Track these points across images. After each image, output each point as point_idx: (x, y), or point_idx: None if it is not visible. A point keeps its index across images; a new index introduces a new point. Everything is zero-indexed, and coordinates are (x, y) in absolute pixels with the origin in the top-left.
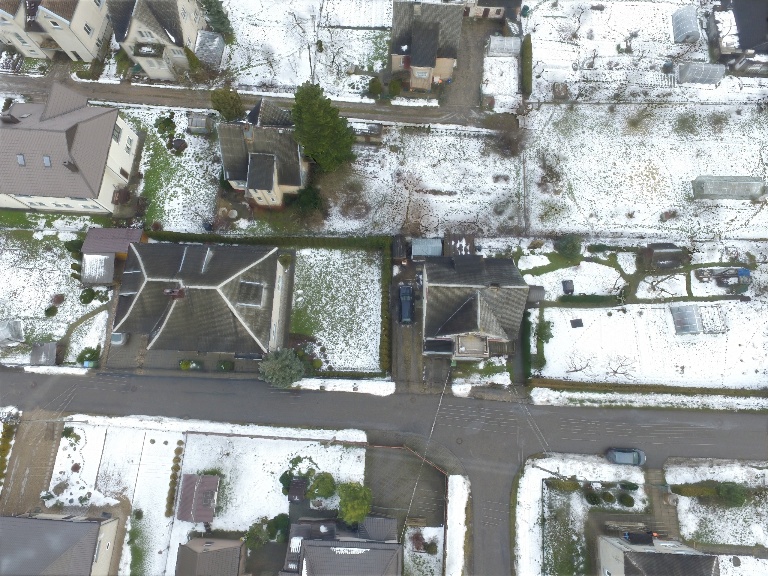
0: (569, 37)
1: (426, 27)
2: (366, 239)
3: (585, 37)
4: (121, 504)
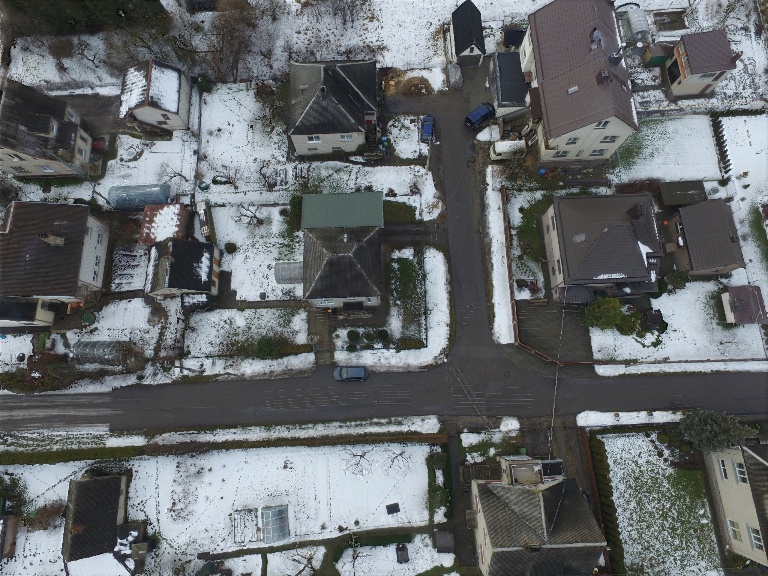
0: None
1: None
2: None
3: None
4: None
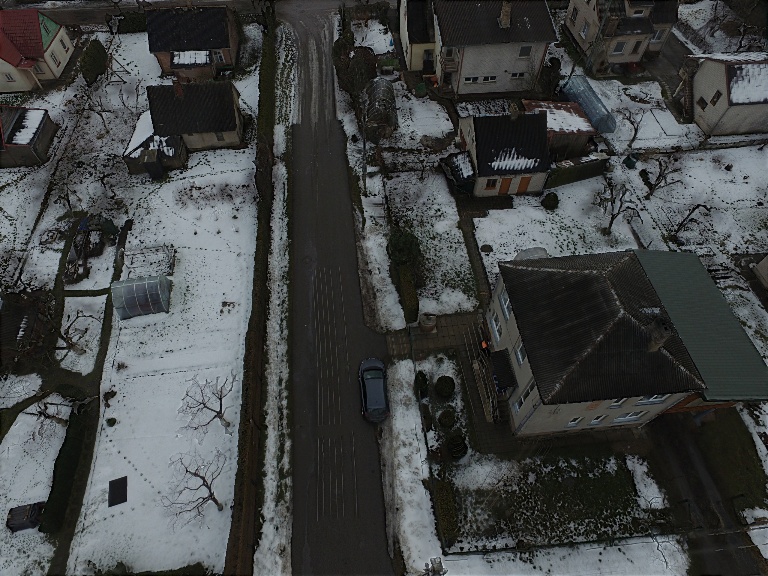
0: None
1: None
2: None
3: None
4: None
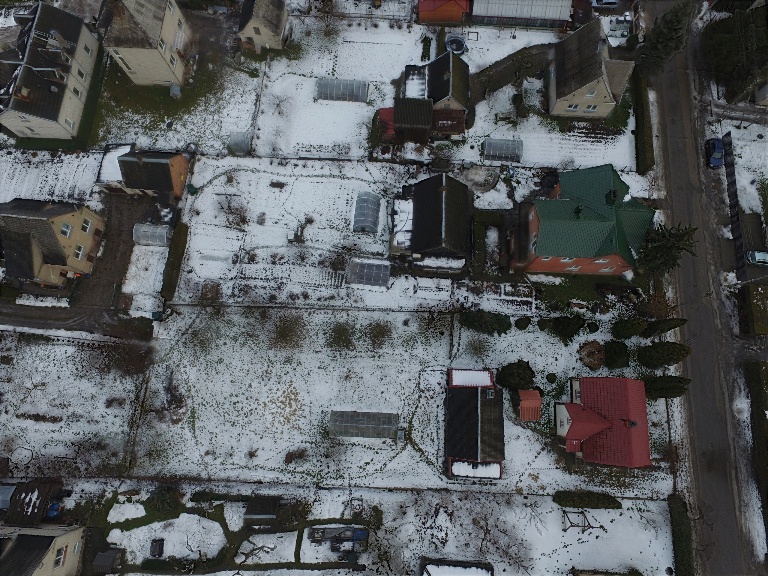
0: (237, 221)
1: (16, 237)
2: None
3: (254, 222)
4: None
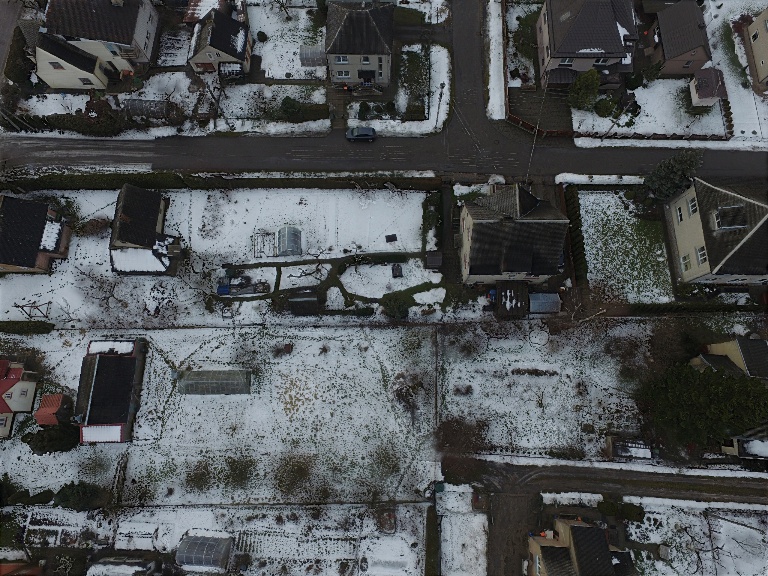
0: None
1: None
2: (611, 305)
3: None
4: (762, 92)
